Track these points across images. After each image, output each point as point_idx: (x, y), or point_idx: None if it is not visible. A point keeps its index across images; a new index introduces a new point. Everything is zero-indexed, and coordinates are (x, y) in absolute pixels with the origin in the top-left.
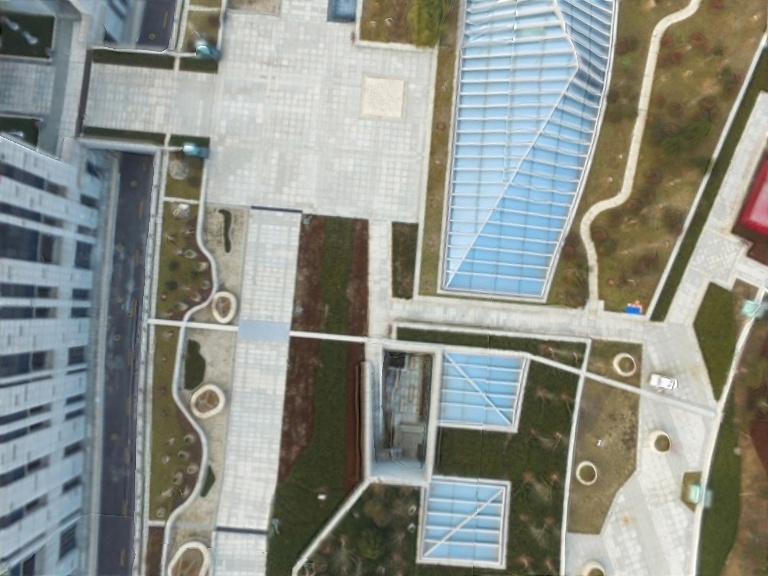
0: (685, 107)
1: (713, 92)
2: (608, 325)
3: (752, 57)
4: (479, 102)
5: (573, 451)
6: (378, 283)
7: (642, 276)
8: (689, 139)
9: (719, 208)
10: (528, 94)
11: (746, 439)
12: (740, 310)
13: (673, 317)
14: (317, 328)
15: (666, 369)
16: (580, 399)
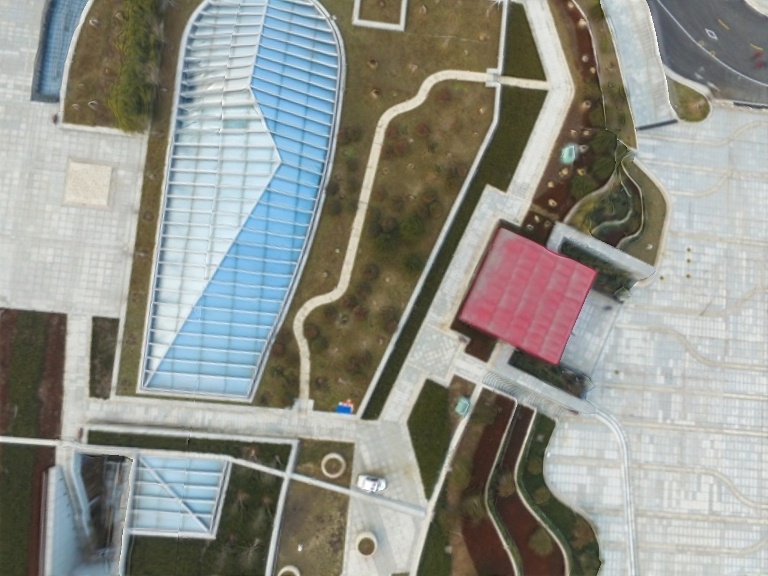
0: (406, 201)
1: (434, 186)
2: (319, 424)
3: (477, 151)
4: (187, 193)
5: (274, 556)
6: (74, 382)
7: (353, 375)
8: (400, 237)
9: (439, 303)
10: (232, 188)
11: (458, 537)
12: (453, 408)
13: (388, 415)
14: (4, 431)
15: (377, 469)
16: (284, 502)
